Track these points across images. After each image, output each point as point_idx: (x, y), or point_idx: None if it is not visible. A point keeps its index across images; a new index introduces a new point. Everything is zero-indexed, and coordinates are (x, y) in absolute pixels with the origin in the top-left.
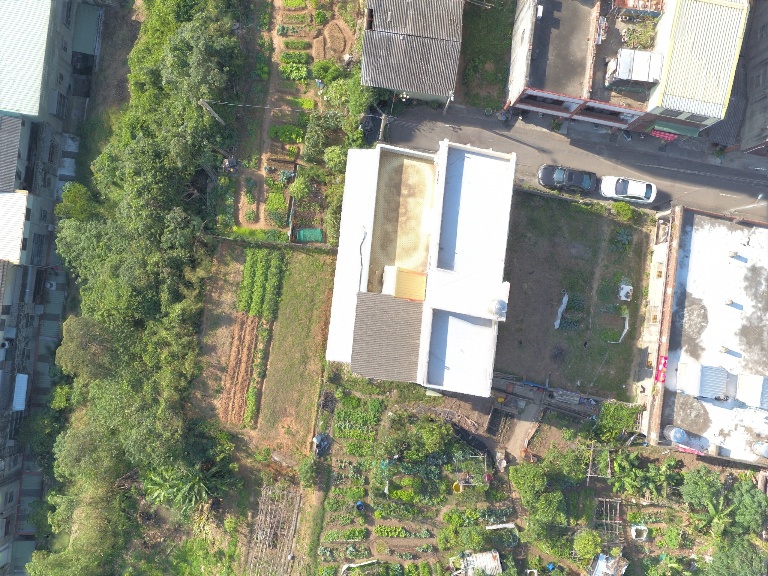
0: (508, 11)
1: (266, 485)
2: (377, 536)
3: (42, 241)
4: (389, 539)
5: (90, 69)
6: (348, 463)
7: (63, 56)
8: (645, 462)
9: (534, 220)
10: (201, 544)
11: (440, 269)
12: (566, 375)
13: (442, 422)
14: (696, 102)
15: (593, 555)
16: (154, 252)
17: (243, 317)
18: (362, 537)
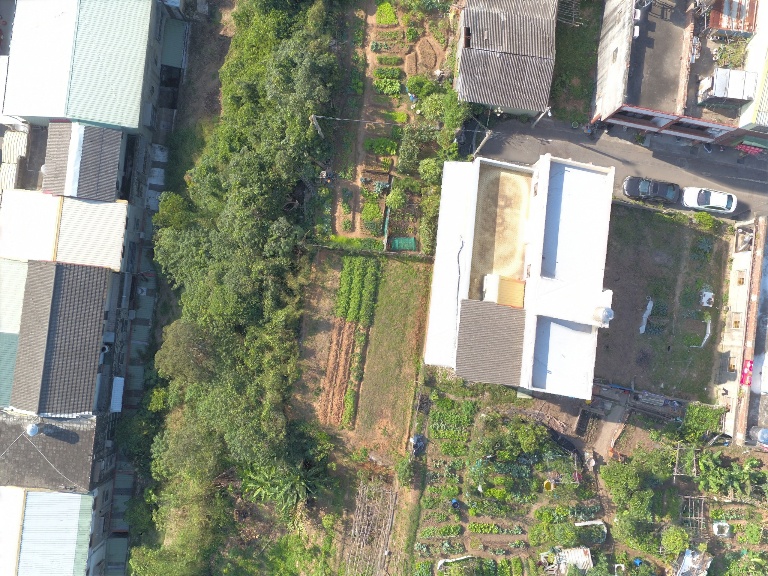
0: (593, 29)
1: (363, 484)
2: (471, 532)
3: (135, 248)
4: (482, 535)
5: (174, 81)
6: (443, 463)
7: (154, 70)
8: (726, 461)
9: (619, 229)
10: (295, 541)
11: (546, 278)
12: (650, 378)
13: (533, 423)
14: None
15: (681, 550)
16: (258, 260)
17: (341, 323)
18: (457, 533)
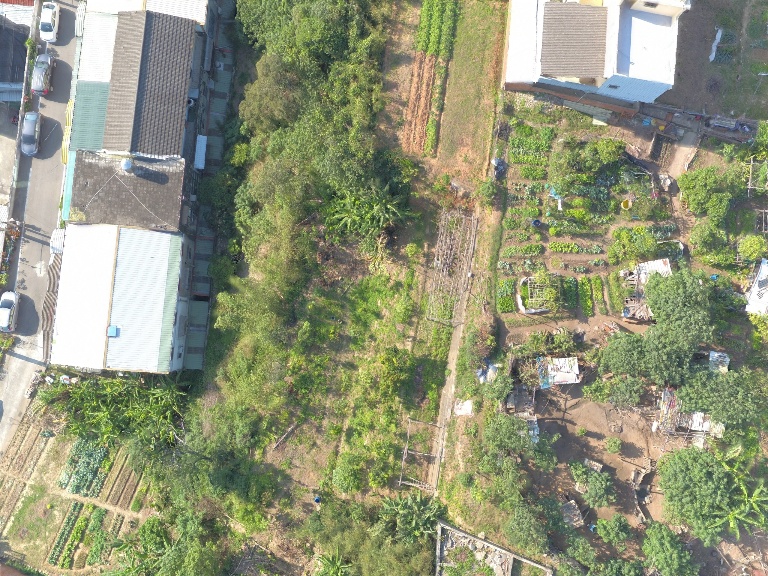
0: None
1: (445, 210)
2: (552, 252)
3: (214, 20)
4: (562, 255)
5: None
6: (523, 185)
7: None
8: None
9: None
10: (377, 281)
11: None
12: (720, 105)
13: None
14: None
15: (758, 255)
16: None
17: (421, 57)
18: (538, 252)
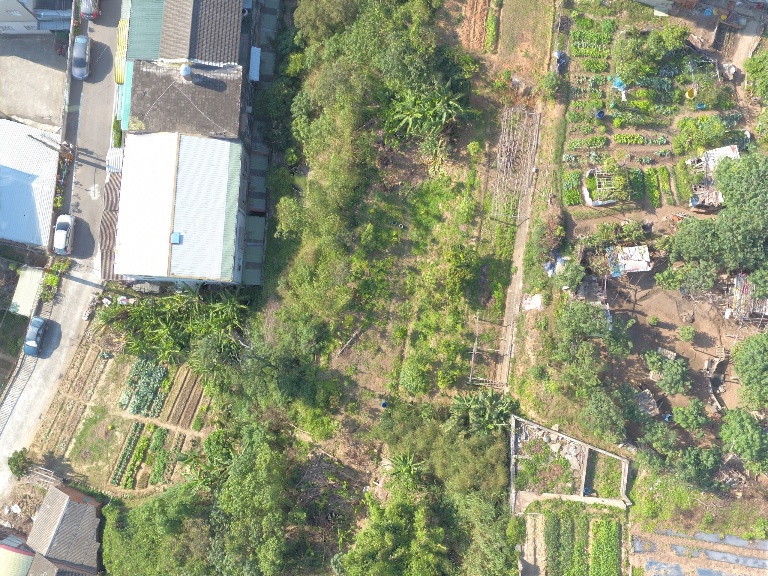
0: None
1: (507, 107)
2: (617, 144)
3: None
4: (627, 147)
5: None
6: (586, 78)
7: None
8: None
9: None
10: (437, 184)
11: None
12: None
13: None
14: None
15: None
16: None
17: None
18: (603, 144)
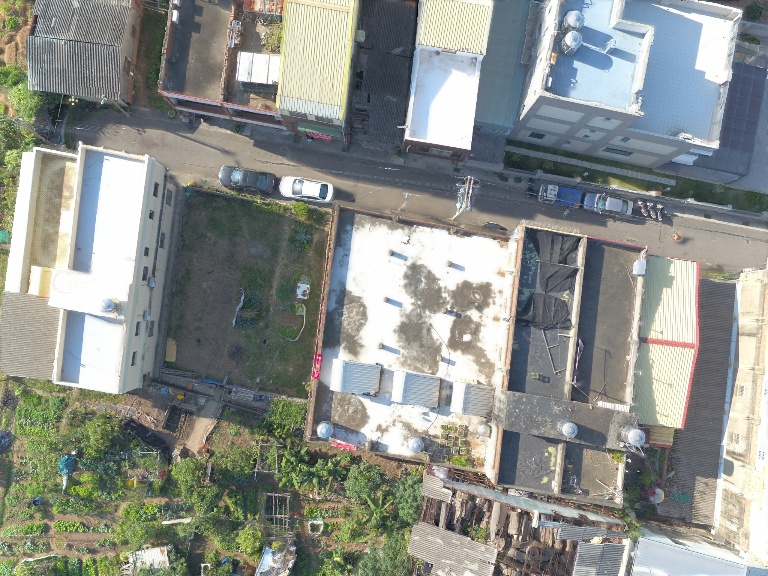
0: None
1: None
2: (56, 531)
3: None
4: (68, 534)
5: None
6: (28, 459)
7: None
8: (323, 458)
9: (214, 220)
10: None
11: (62, 269)
12: (245, 372)
13: (118, 419)
14: (313, 103)
15: (254, 549)
16: None
17: None
18: (40, 532)
